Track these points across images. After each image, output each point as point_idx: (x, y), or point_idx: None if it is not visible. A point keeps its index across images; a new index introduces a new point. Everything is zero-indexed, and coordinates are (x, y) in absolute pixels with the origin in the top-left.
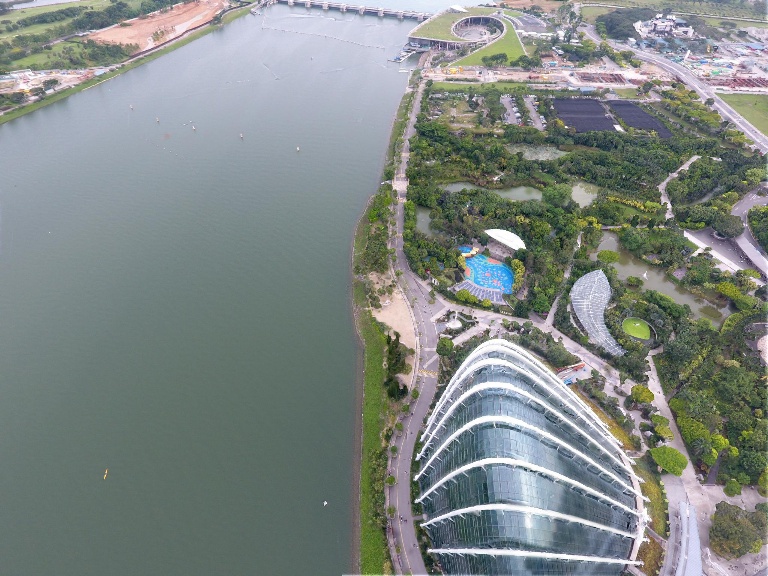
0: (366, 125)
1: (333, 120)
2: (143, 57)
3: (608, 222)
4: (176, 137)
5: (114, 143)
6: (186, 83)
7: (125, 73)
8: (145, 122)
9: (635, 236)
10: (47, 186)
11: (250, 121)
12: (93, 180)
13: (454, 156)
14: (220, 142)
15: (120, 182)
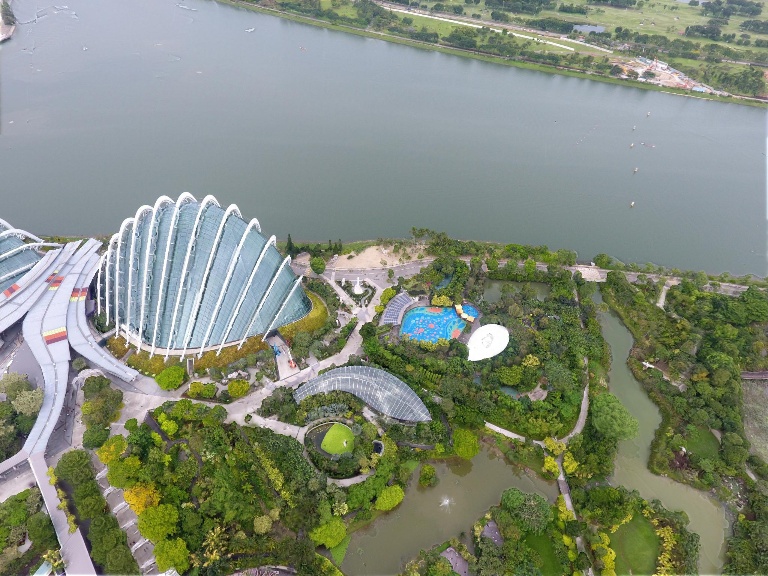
0: (749, 259)
1: (736, 231)
2: (763, 102)
3: (574, 491)
4: (612, 141)
5: (581, 118)
6: (734, 132)
7: (725, 104)
8: (626, 123)
9: (516, 493)
10: (506, 106)
11: (676, 173)
12: (521, 119)
13: (686, 323)
14: (619, 162)
15: (523, 128)
